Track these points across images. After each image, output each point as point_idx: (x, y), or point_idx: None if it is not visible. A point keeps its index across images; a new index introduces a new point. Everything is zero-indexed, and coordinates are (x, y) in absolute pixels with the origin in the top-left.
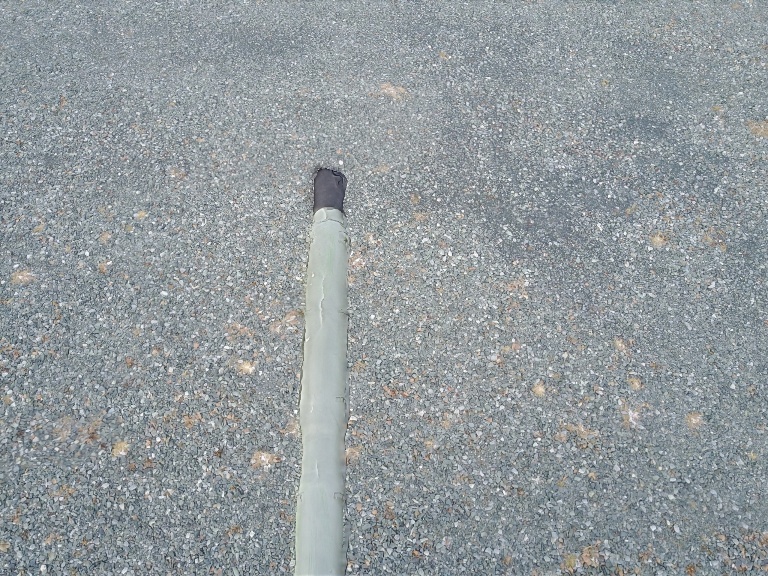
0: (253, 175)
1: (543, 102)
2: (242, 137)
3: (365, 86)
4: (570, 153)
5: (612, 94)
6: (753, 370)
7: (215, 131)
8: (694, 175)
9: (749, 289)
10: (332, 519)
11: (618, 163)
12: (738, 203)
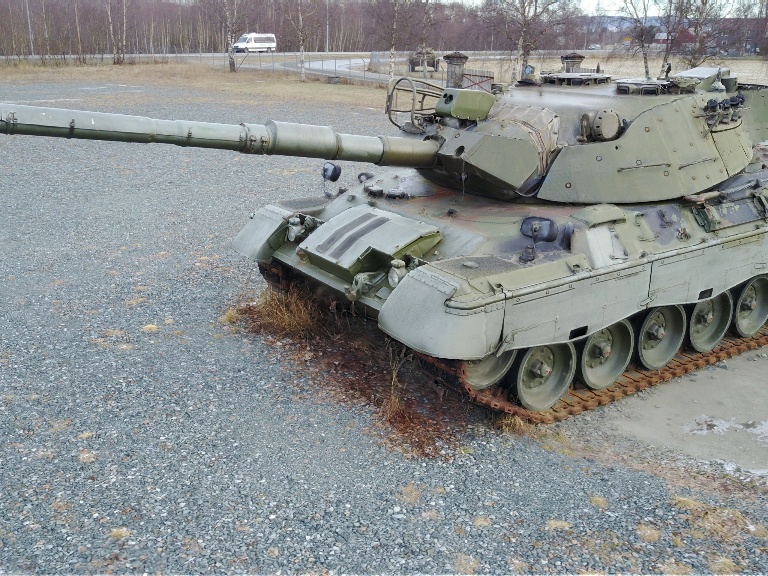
0: None
1: None
2: None
3: None
4: None
5: None
6: None
7: None
8: None
9: None
10: None
11: None
12: None
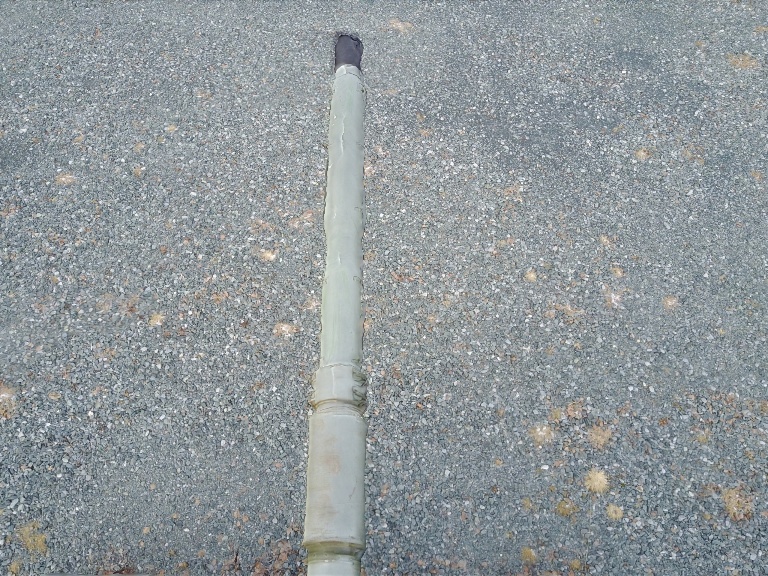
0: (273, 96)
1: (539, 37)
2: (262, 64)
3: (375, 21)
4: (563, 80)
5: (603, 30)
6: (725, 262)
7: (237, 59)
8: (677, 100)
9: (724, 196)
10: (352, 295)
11: (607, 89)
12: (716, 124)
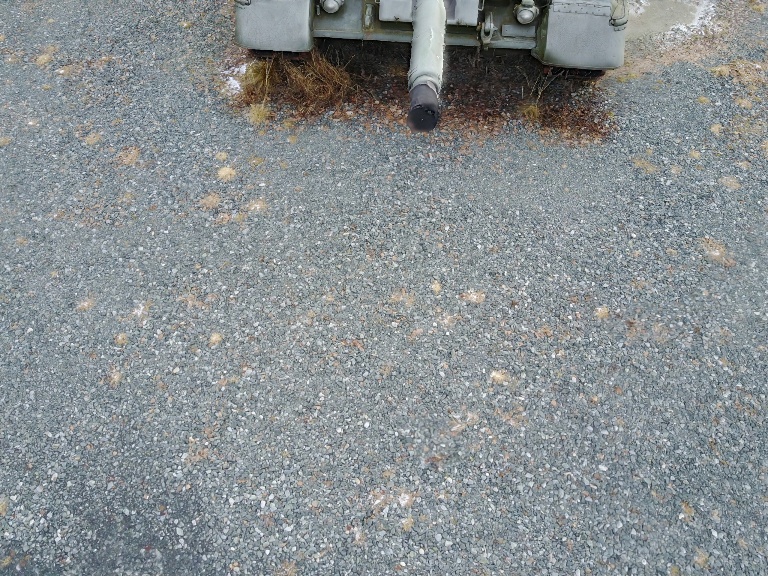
0: None
1: None
2: None
3: None
4: None
5: None
6: None
7: None
8: None
9: None
10: None
11: None
12: None
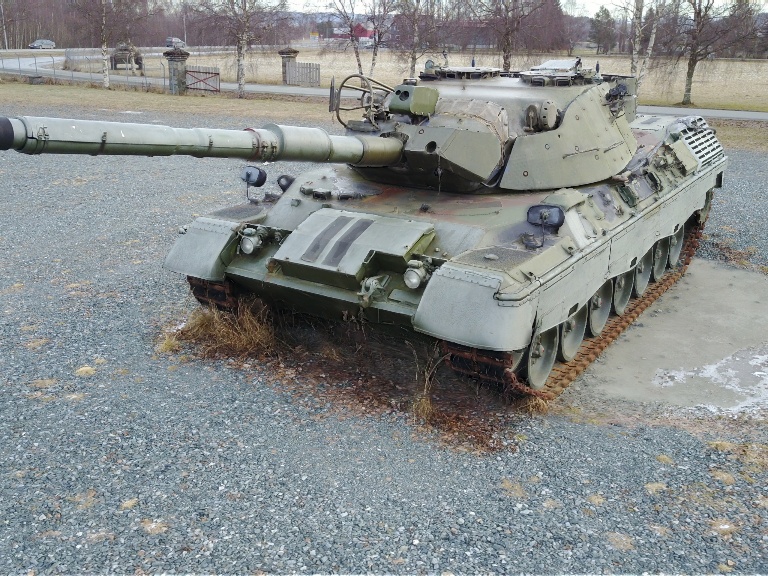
0: None
1: None
2: None
3: None
4: None
5: None
6: None
7: None
8: None
9: None
10: None
11: None
12: None
